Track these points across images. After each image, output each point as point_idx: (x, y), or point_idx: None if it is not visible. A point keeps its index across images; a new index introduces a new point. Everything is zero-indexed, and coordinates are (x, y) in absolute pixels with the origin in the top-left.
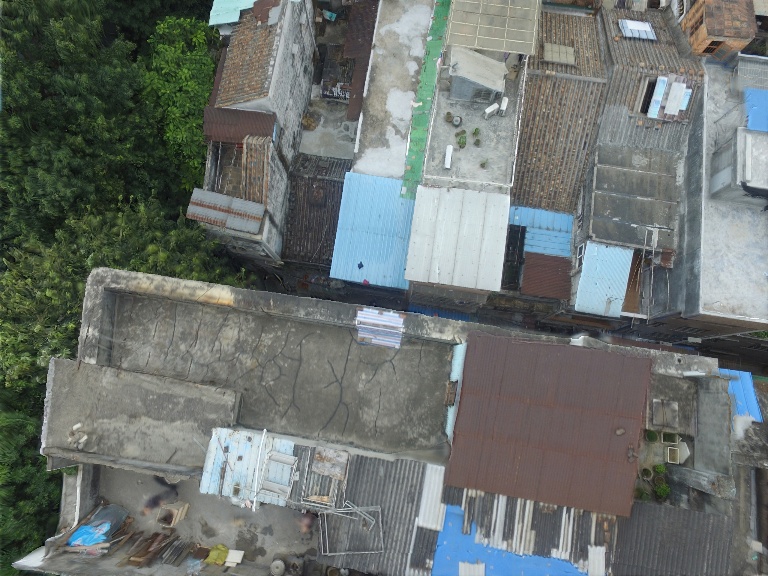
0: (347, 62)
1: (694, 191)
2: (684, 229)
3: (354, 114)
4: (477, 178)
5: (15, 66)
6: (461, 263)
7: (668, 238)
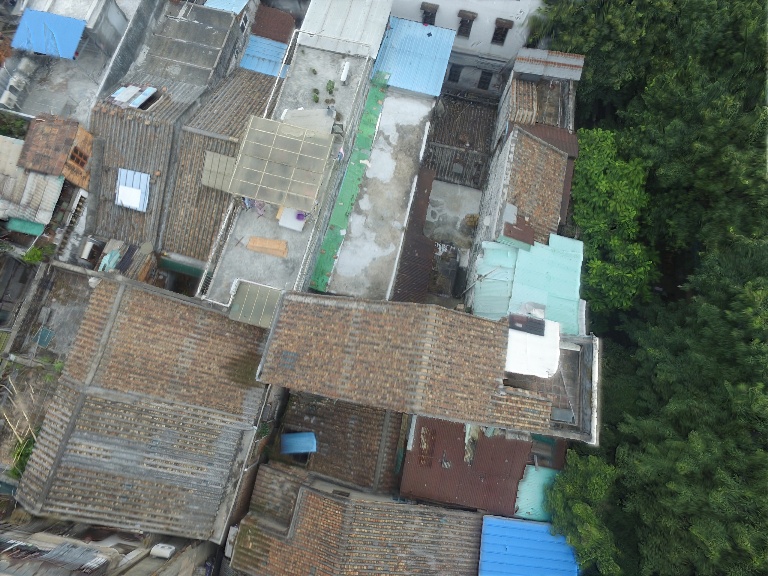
0: (430, 274)
1: (142, 19)
2: (159, 3)
3: (428, 172)
4: (322, 63)
5: (761, 54)
6: (347, 0)
7: (172, 11)
